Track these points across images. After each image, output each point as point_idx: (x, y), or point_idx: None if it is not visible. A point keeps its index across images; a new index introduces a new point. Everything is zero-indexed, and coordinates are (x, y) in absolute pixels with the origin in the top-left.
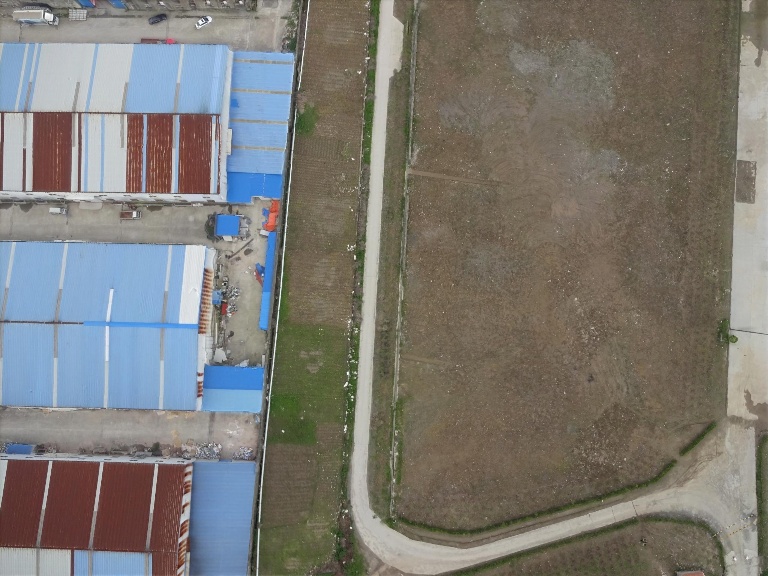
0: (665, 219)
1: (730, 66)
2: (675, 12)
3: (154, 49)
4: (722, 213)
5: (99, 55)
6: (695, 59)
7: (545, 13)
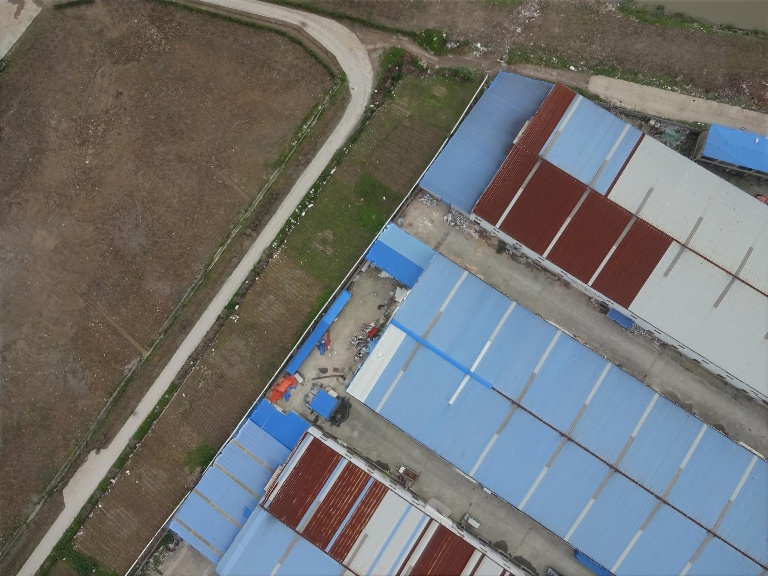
0: None
1: None
2: None
3: None
4: None
5: None
6: None
7: None
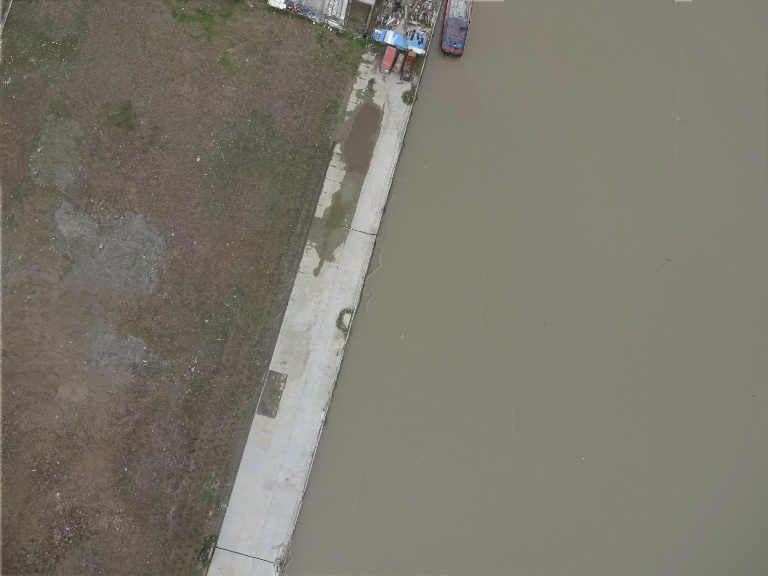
0: (177, 421)
1: (287, 271)
2: (245, 203)
3: None
4: (239, 423)
5: None
6: (253, 257)
7: (106, 176)
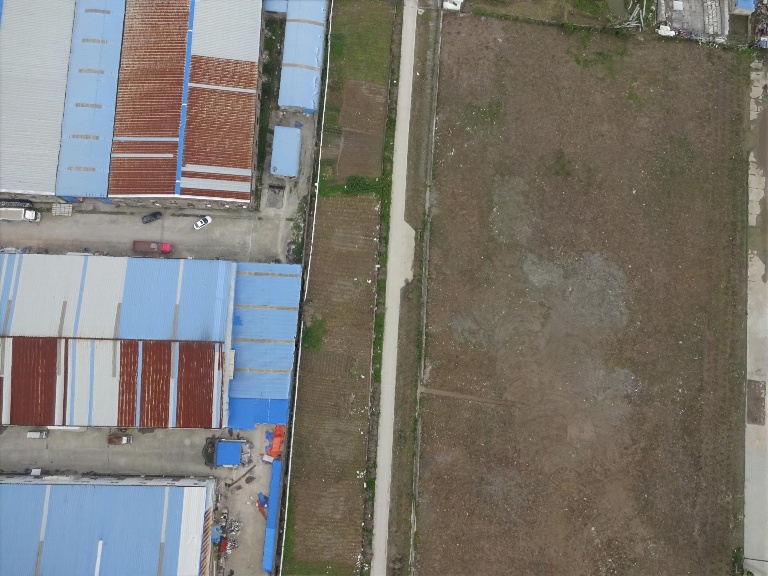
0: (679, 442)
1: (739, 282)
2: (685, 225)
3: (150, 264)
4: (734, 435)
5: (89, 270)
6: (705, 274)
7: (559, 223)
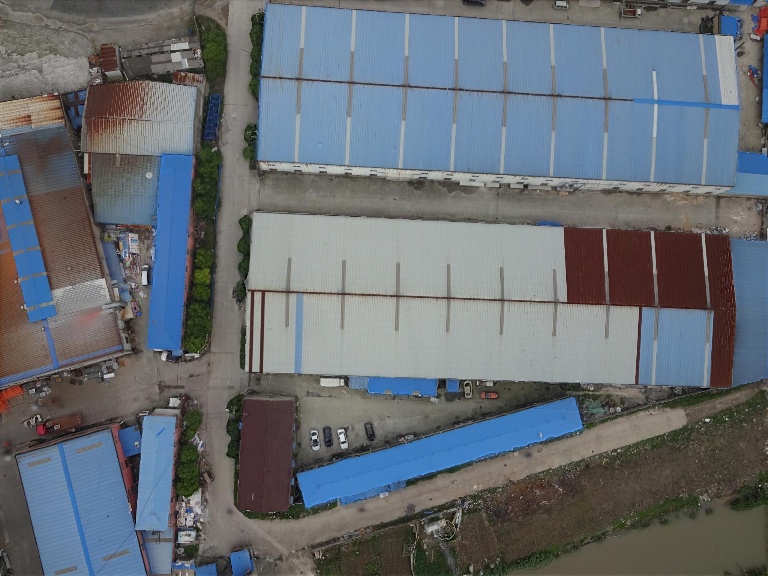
0: None
1: None
2: None
3: None
4: None
5: None
6: None
7: None
